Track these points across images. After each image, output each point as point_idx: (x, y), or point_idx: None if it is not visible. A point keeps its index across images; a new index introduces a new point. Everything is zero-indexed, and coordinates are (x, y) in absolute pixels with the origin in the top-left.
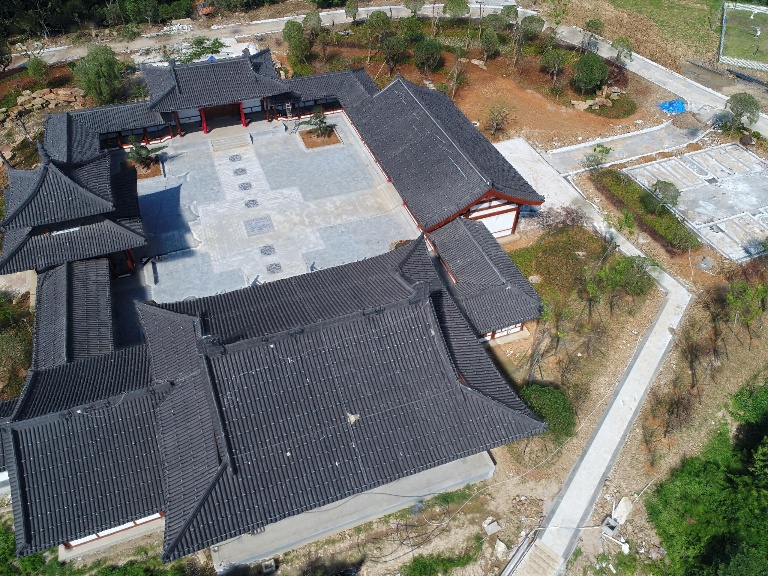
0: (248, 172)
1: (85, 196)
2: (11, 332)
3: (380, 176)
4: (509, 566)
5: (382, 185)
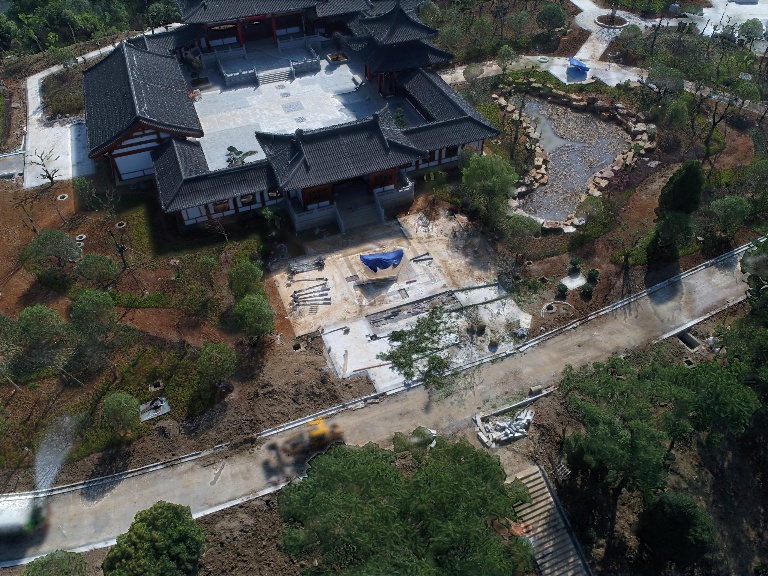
0: None
1: None
2: None
3: None
4: None
5: None
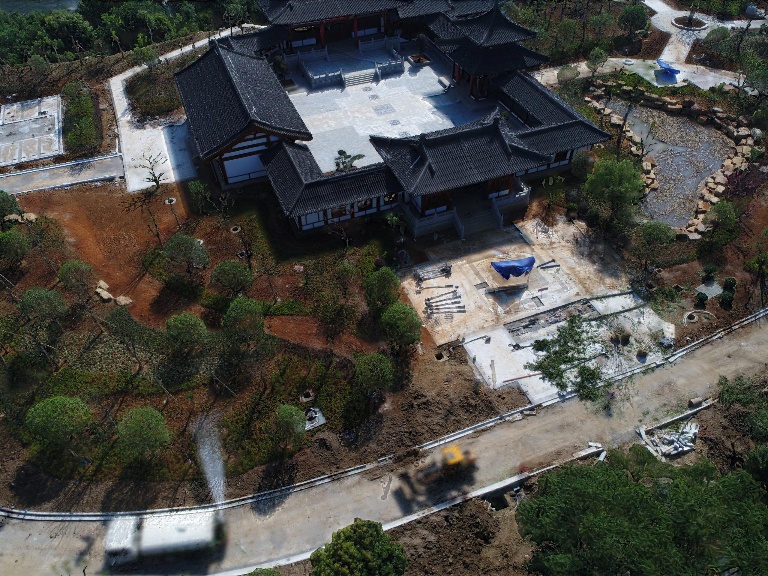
0: None
1: None
2: None
3: None
4: None
5: None
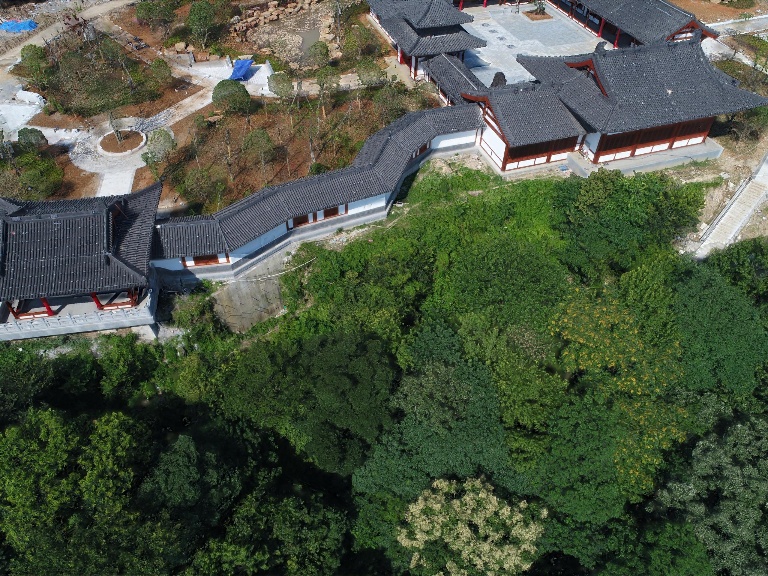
0: (499, 32)
1: (454, 13)
2: (406, 96)
3: (590, 35)
4: (737, 193)
5: (594, 39)
